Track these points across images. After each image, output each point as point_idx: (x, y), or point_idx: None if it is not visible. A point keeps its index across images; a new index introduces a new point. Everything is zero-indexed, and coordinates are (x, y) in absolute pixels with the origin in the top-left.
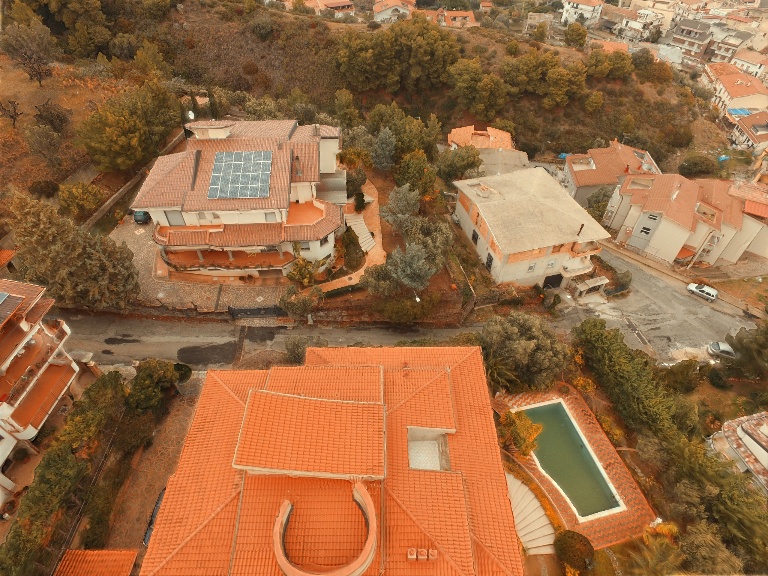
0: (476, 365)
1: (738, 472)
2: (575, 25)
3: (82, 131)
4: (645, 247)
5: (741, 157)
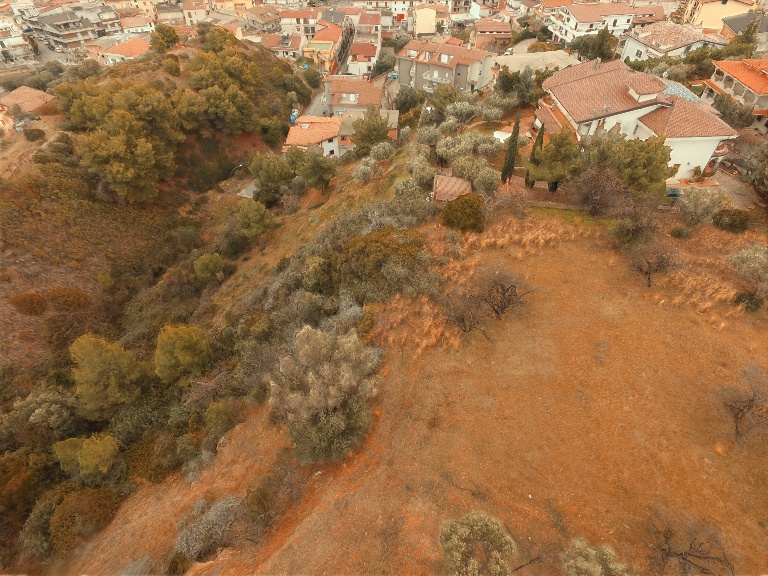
0: None
1: (700, 48)
2: (164, 25)
3: None
4: (481, 83)
5: (304, 62)
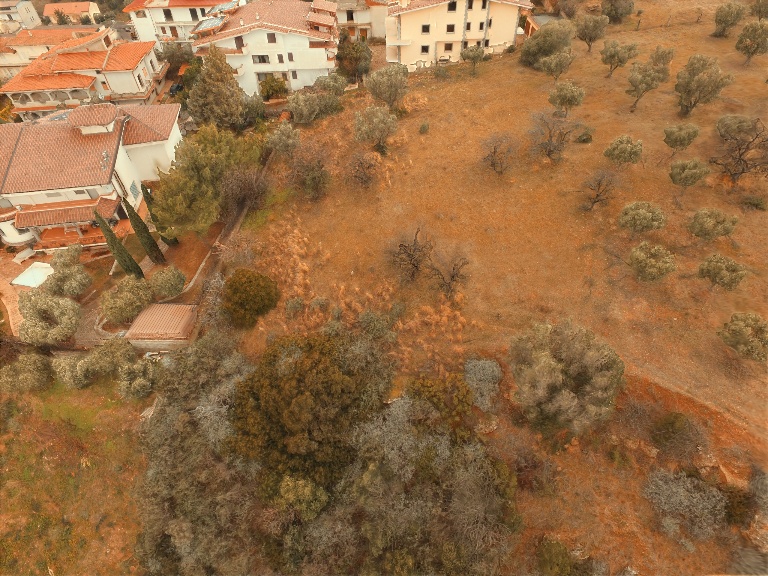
0: (6, 85)
1: None
2: None
3: (253, 151)
4: None
5: None
